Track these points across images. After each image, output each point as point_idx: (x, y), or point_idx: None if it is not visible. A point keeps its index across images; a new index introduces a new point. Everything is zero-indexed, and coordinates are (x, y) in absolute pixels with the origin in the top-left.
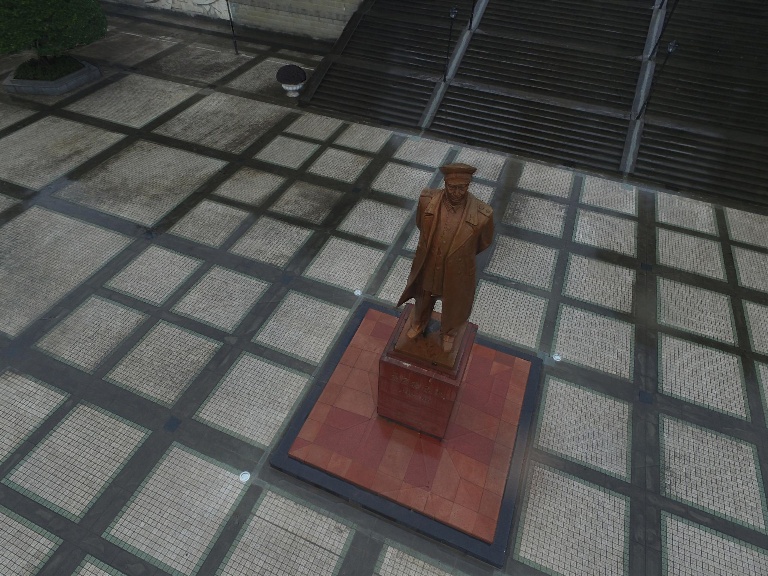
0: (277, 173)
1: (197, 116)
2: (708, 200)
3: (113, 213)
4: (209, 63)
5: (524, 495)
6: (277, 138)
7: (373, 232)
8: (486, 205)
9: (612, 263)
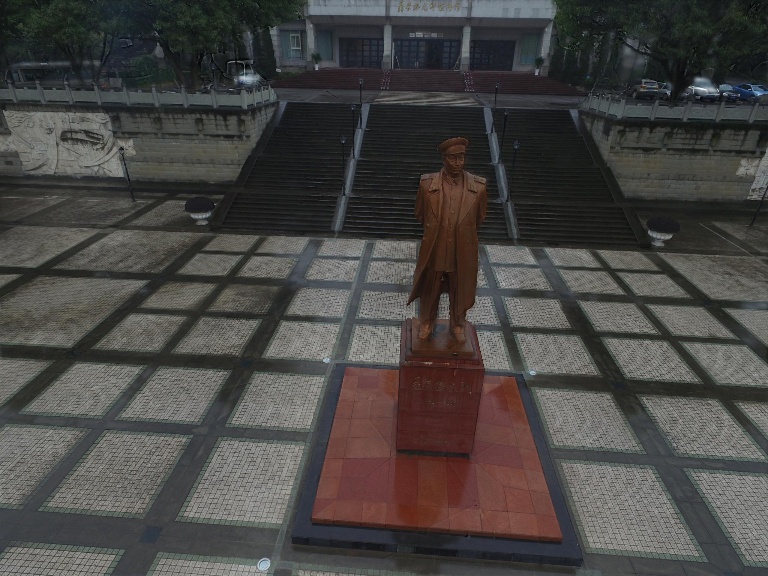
0: (206, 281)
1: (103, 250)
2: (582, 248)
3: (18, 343)
4: (105, 210)
5: (565, 491)
6: (197, 256)
7: (322, 311)
8: None
9: (538, 298)
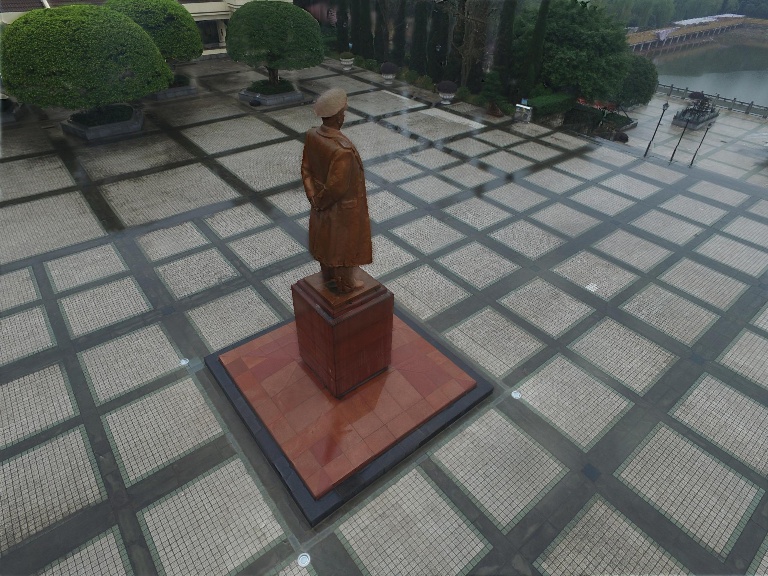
0: None
1: None
2: None
3: None
4: None
5: None
6: None
7: None
8: (314, 127)
9: None
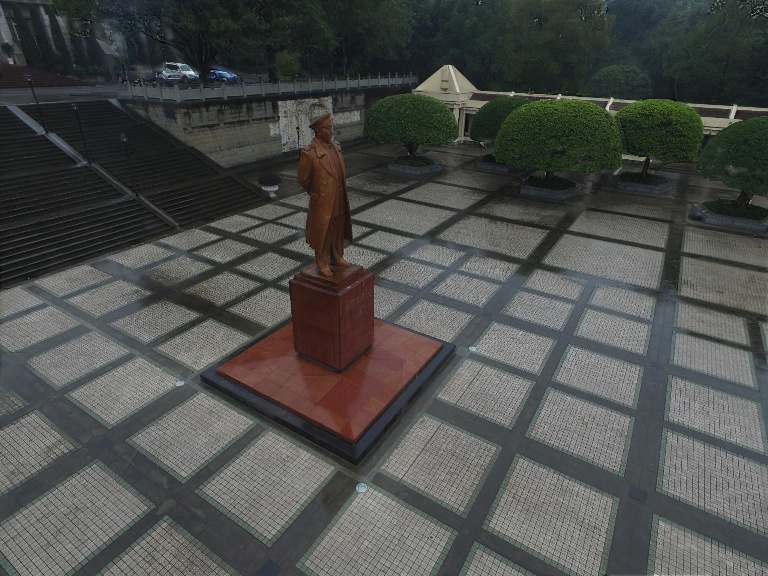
0: None
1: None
2: (232, 214)
3: None
4: None
5: None
6: None
7: (97, 361)
8: None
9: (257, 257)
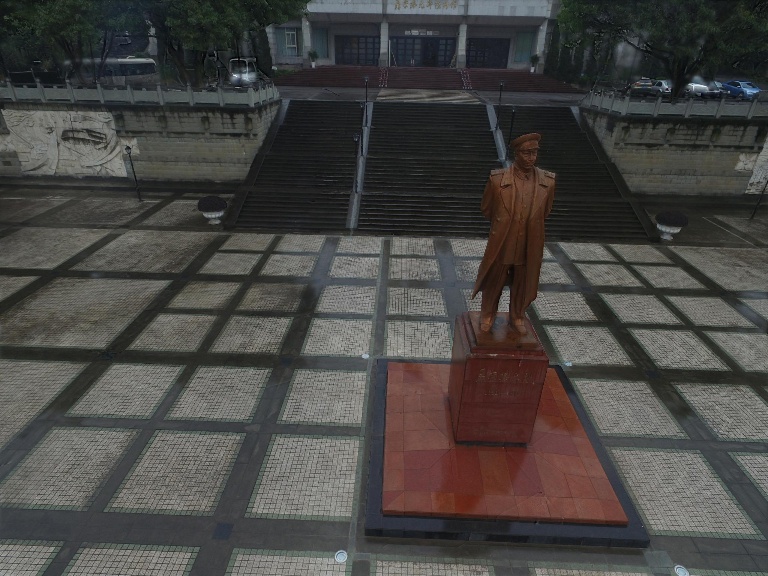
0: (230, 280)
1: (118, 250)
2: (595, 242)
3: (50, 345)
4: (113, 210)
5: (620, 477)
6: (215, 255)
7: (351, 308)
8: None
9: (561, 291)
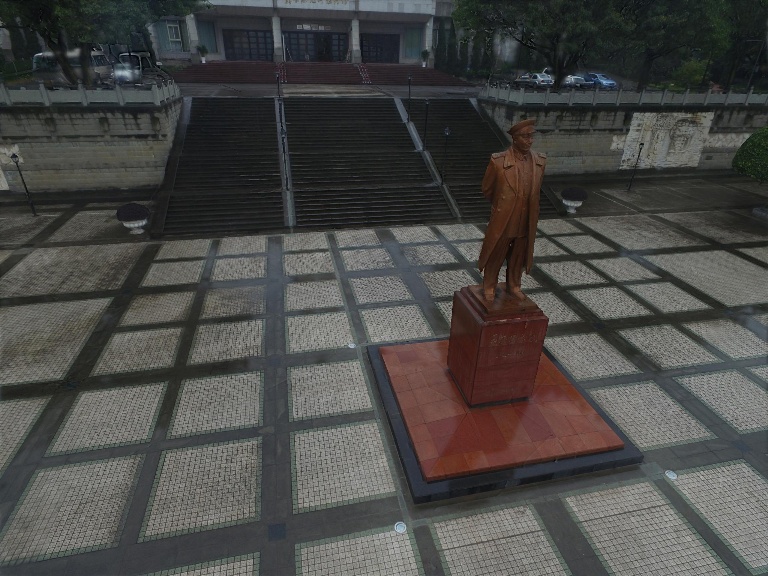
0: (180, 290)
1: (31, 272)
2: None
3: None
4: (4, 229)
5: None
6: (152, 266)
7: (320, 302)
8: None
9: (503, 265)
